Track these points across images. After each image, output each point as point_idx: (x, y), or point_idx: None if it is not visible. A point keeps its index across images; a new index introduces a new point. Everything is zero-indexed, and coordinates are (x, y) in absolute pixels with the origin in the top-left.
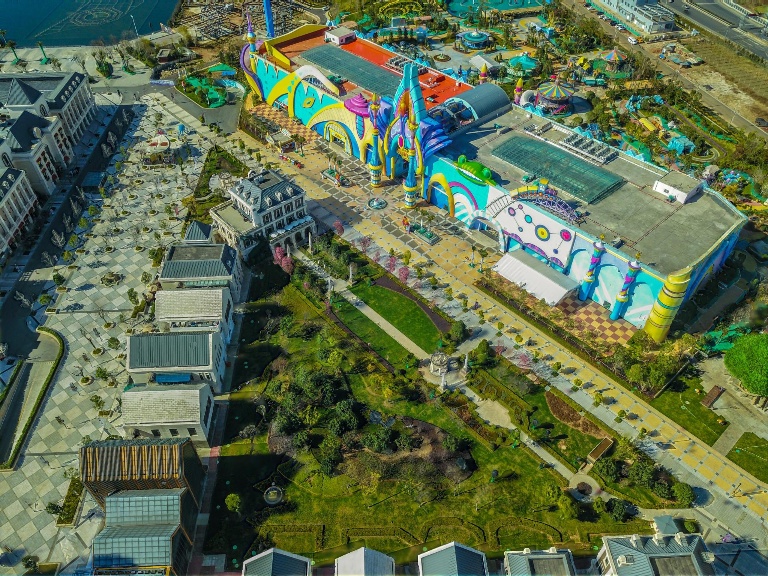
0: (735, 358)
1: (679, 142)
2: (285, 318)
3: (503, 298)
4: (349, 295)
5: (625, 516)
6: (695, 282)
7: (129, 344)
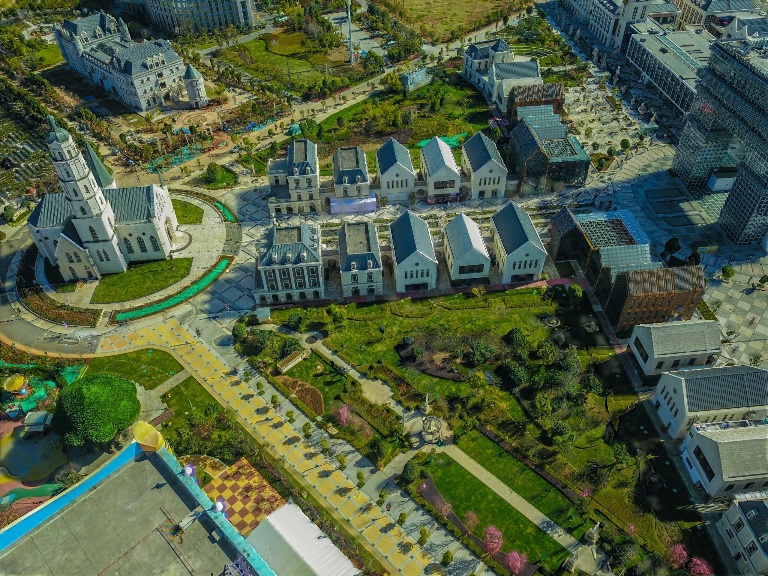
0: (132, 405)
1: None
2: (626, 457)
3: (349, 544)
4: (566, 540)
5: (287, 325)
6: None
7: (762, 369)
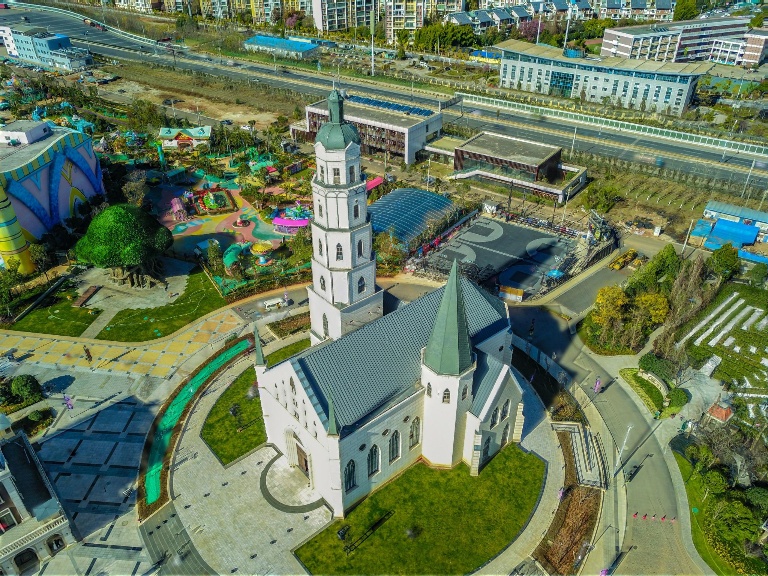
0: (78, 244)
1: (76, 125)
2: None
3: None
4: None
5: None
6: (50, 204)
7: None
